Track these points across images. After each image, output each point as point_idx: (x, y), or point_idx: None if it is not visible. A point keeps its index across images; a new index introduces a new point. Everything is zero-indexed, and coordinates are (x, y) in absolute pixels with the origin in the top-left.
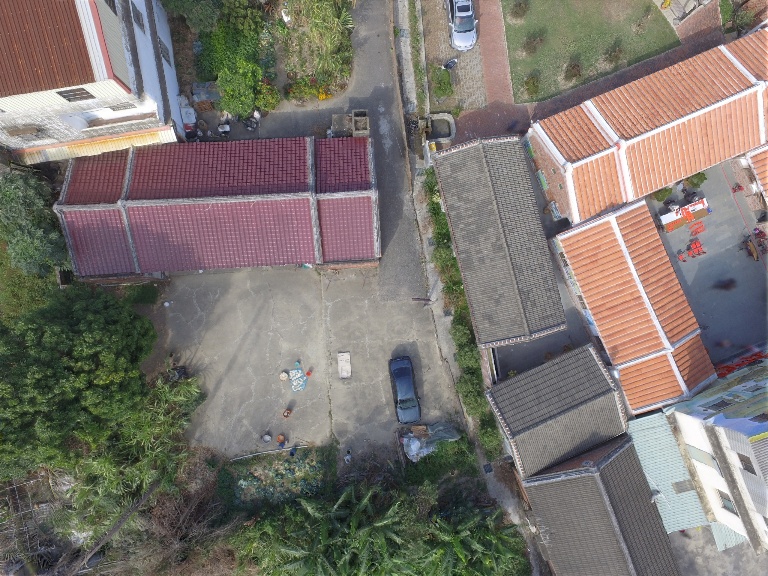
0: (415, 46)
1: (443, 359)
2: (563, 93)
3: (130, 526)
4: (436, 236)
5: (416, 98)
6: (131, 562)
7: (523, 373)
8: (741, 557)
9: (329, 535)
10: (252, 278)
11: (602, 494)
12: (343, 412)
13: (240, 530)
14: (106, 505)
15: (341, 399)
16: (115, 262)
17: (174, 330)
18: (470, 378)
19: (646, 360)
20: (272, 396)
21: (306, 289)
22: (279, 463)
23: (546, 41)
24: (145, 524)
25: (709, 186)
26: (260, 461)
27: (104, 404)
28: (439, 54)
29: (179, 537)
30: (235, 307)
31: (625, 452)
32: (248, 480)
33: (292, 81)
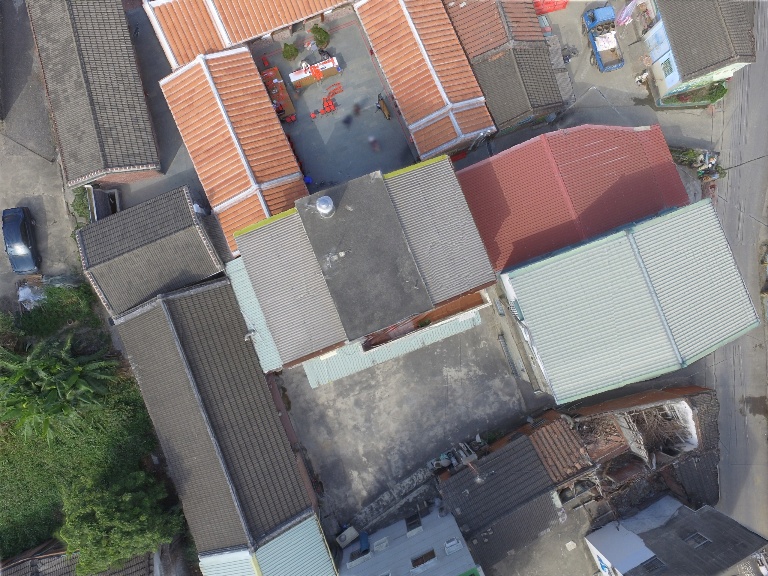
0: None
1: (70, 213)
2: None
3: None
4: None
5: None
6: None
7: (116, 213)
8: (373, 410)
9: None
10: None
11: None
12: None
13: None
14: None
15: None
16: None
17: None
18: None
19: (240, 201)
20: None
21: None
22: None
23: None
24: None
25: (348, 49)
26: None
27: None
28: None
29: None
30: None
31: (217, 290)
32: None
33: None
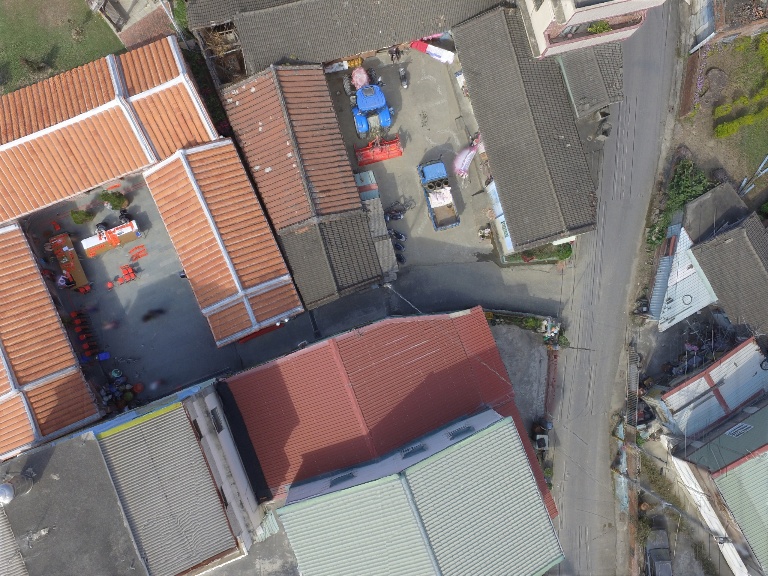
0: None
1: None
2: None
3: None
4: None
5: None
6: None
7: None
8: None
9: None
10: None
11: None
12: None
13: None
14: None
15: None
16: None
17: None
18: None
19: (5, 401)
20: None
21: None
22: None
23: None
24: None
25: (154, 207)
26: None
27: None
28: None
29: None
30: None
31: None
32: None
33: None
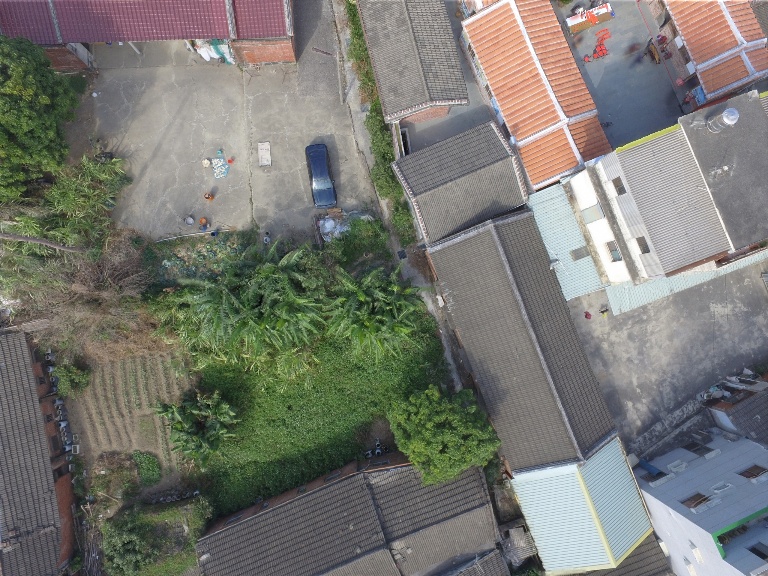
0: None
1: (359, 152)
2: None
3: (54, 288)
4: (353, 36)
5: None
6: (55, 323)
7: (428, 146)
8: (645, 343)
9: (235, 275)
10: (177, 72)
11: (497, 245)
12: (263, 198)
13: (160, 296)
14: (30, 265)
15: (261, 186)
16: (38, 32)
17: (102, 119)
18: (383, 164)
19: (545, 135)
20: (195, 182)
21: (229, 84)
22: (201, 246)
23: None
24: (68, 287)
25: None
26: (183, 243)
27: (11, 113)
28: None
29: (95, 282)
30: (160, 99)
31: (525, 220)
32: (171, 260)
33: None
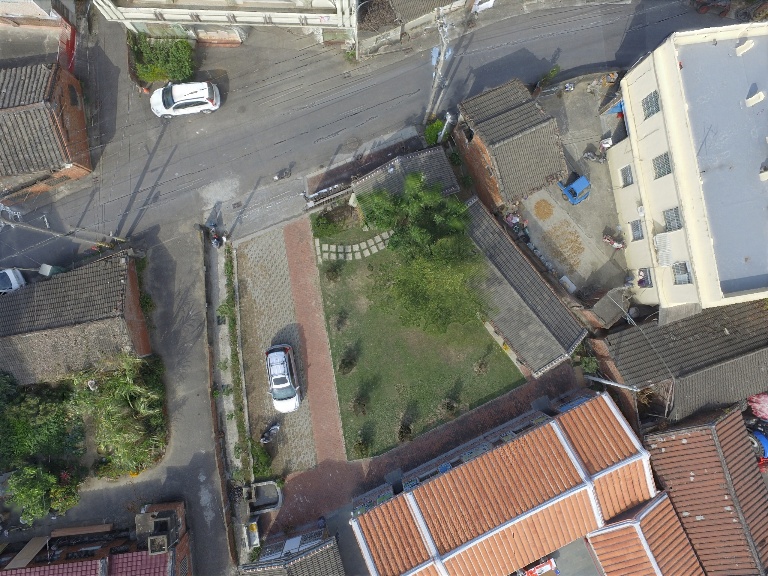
0: (239, 403)
1: None
2: (400, 445)
3: None
4: None
5: (241, 461)
6: None
7: None
8: None
9: None
10: None
11: None
12: None
13: None
14: None
15: None
16: None
17: None
18: None
19: None
20: None
21: None
22: None
23: (380, 389)
24: None
25: None
26: None
27: None
28: (264, 412)
29: None
30: None
31: None
32: None
33: (103, 455)
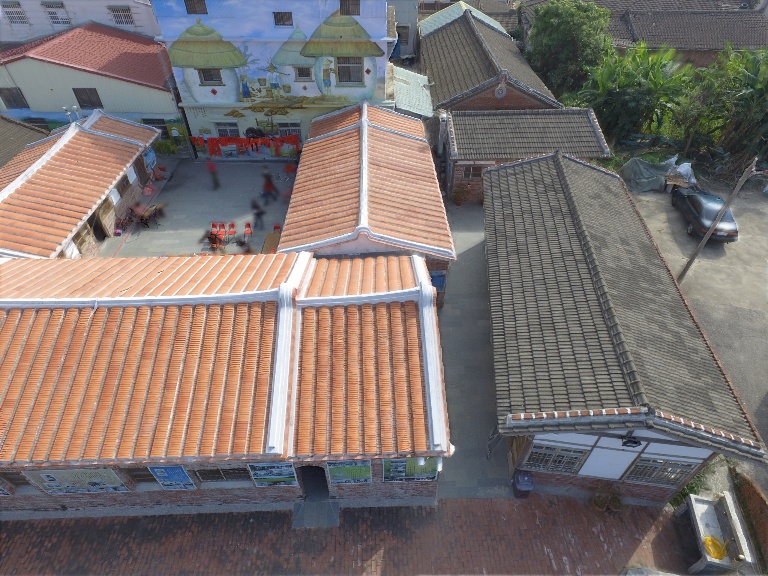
0: None
1: None
2: None
3: None
4: None
5: None
6: None
7: None
8: None
9: None
10: None
11: None
12: None
13: None
14: None
15: None
16: None
17: None
18: None
19: None
20: None
21: None
22: None
23: None
24: None
25: None
26: None
27: None
28: None
29: None
30: None
31: None
32: None
33: None
